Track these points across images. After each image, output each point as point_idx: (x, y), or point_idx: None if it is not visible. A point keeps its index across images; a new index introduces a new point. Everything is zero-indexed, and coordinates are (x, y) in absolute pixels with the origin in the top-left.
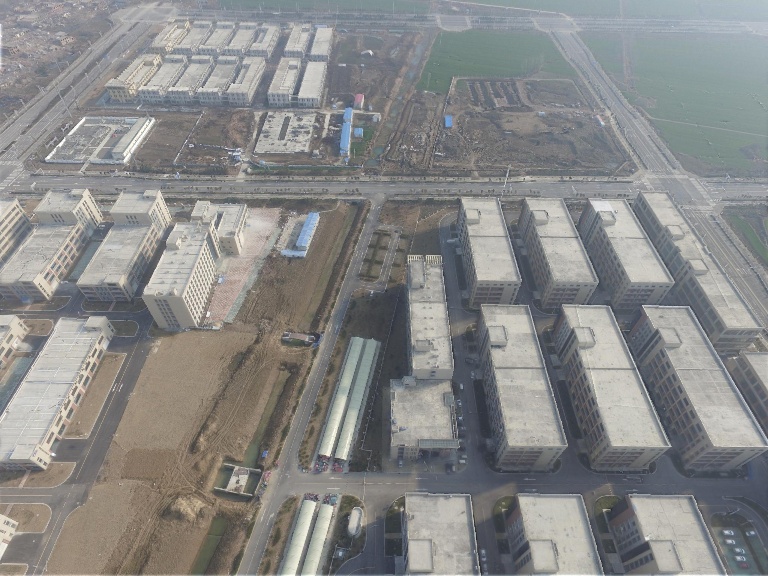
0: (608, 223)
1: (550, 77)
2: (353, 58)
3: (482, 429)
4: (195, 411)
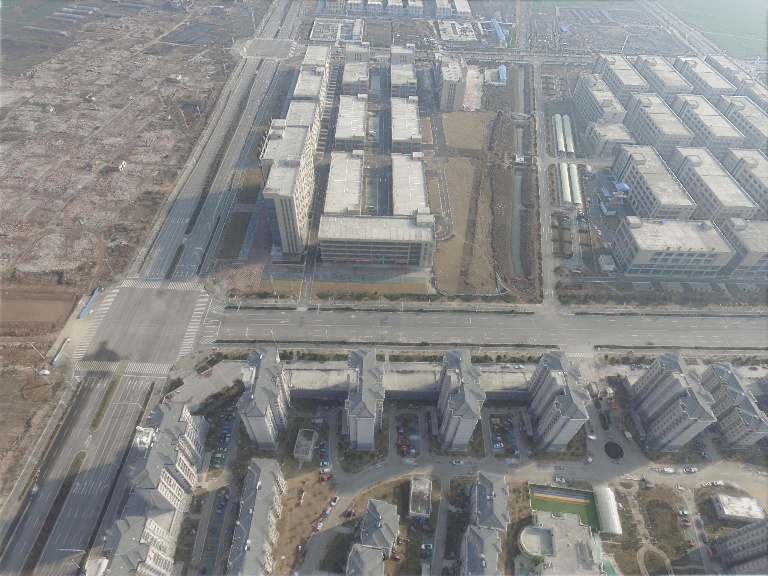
0: (692, 66)
1: (625, 8)
2: None
3: None
4: (482, 138)
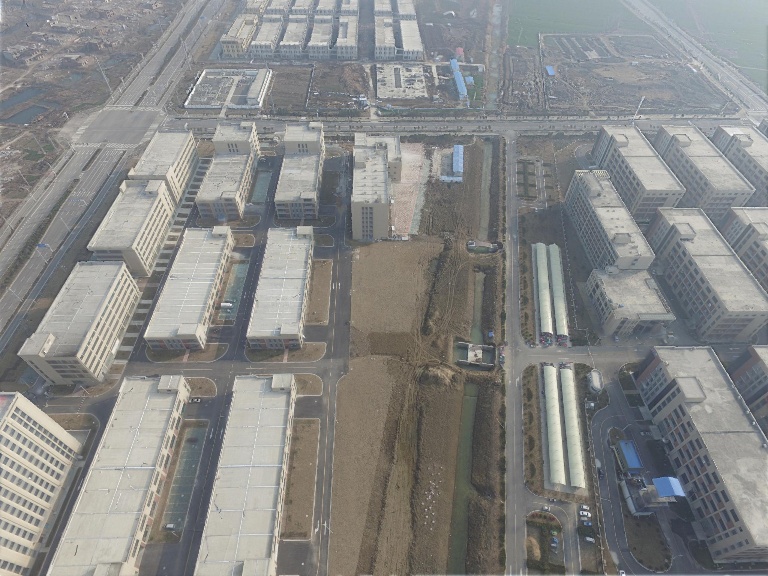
0: (745, 144)
1: (631, 33)
2: (437, 18)
3: (678, 312)
4: (414, 303)
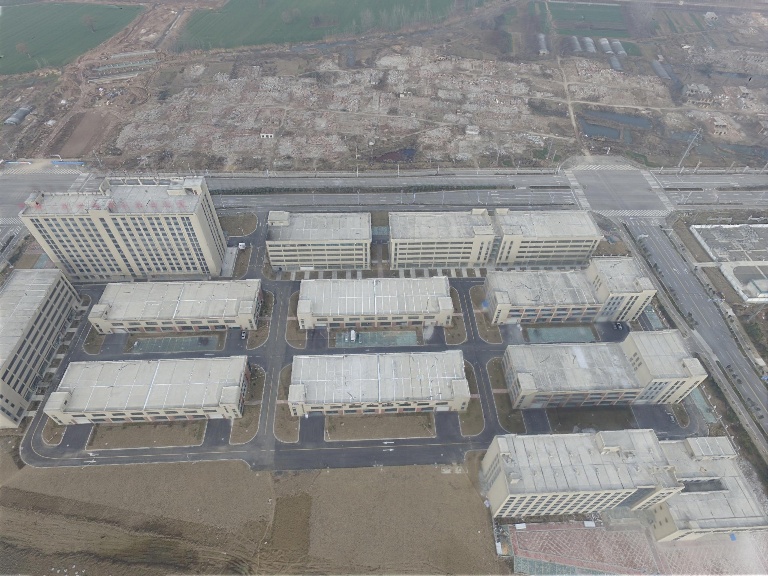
0: None
1: None
2: None
3: None
4: (362, 562)
